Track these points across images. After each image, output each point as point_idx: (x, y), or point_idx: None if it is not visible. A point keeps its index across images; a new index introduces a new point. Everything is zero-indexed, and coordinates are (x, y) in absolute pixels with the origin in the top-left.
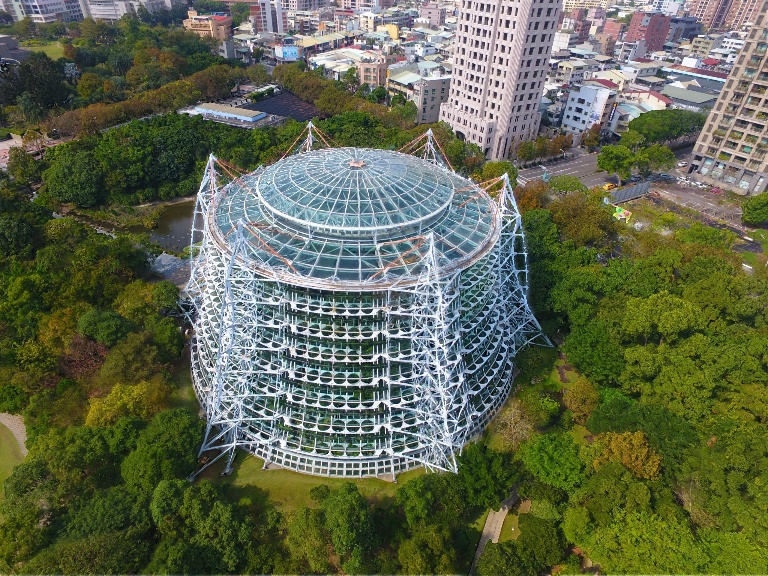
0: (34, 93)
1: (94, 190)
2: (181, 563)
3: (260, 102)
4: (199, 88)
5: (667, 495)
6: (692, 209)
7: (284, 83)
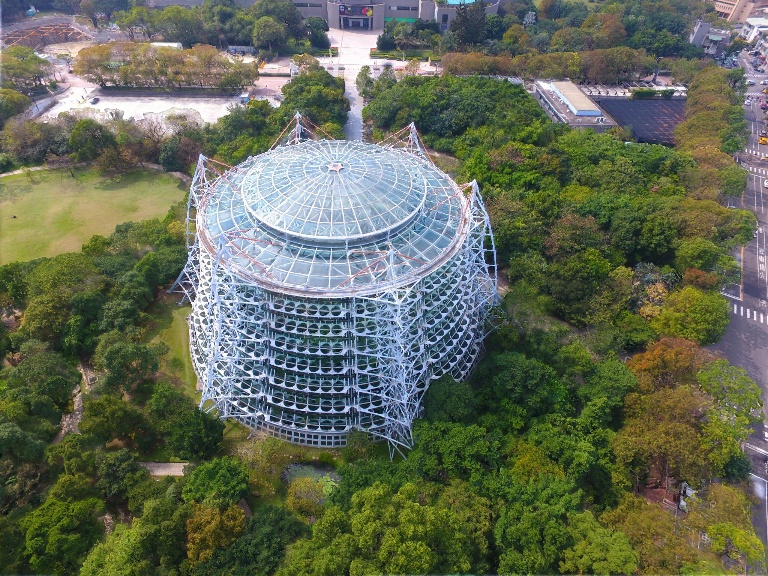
0: (460, 31)
1: (387, 116)
2: (84, 301)
3: (638, 100)
4: (583, 65)
5: (169, 574)
6: None
7: (688, 89)
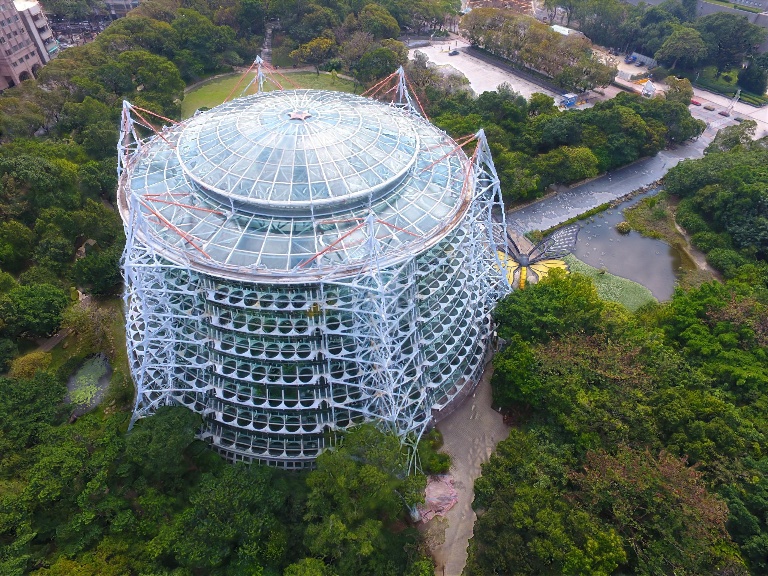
0: None
1: (687, 183)
2: None
3: None
4: None
5: None
6: None
7: None
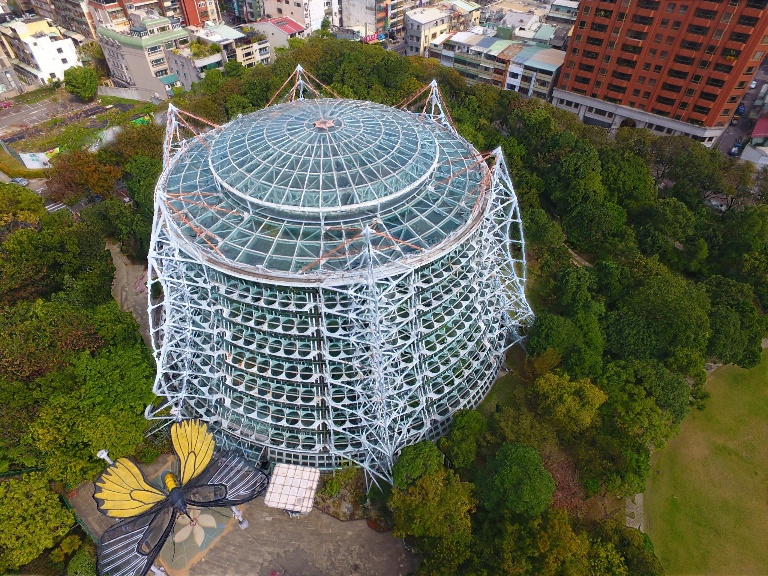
0: None
1: None
2: None
3: None
4: None
5: None
6: (46, 121)
7: None
